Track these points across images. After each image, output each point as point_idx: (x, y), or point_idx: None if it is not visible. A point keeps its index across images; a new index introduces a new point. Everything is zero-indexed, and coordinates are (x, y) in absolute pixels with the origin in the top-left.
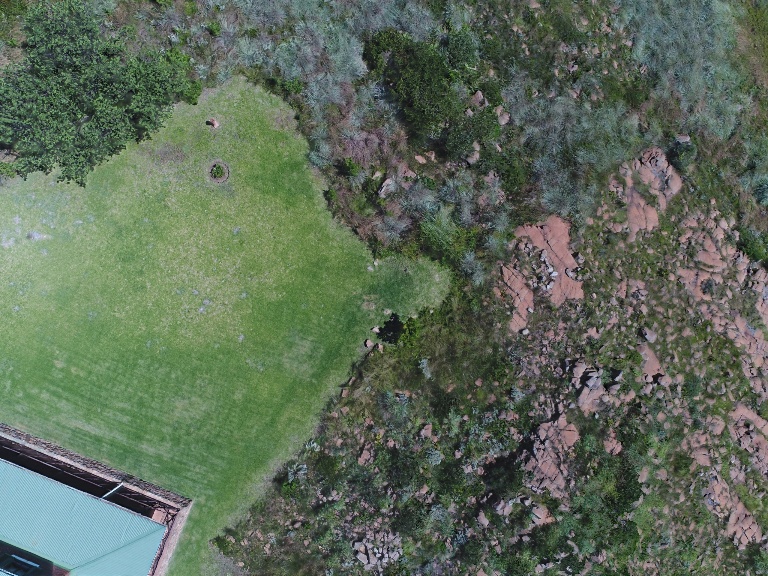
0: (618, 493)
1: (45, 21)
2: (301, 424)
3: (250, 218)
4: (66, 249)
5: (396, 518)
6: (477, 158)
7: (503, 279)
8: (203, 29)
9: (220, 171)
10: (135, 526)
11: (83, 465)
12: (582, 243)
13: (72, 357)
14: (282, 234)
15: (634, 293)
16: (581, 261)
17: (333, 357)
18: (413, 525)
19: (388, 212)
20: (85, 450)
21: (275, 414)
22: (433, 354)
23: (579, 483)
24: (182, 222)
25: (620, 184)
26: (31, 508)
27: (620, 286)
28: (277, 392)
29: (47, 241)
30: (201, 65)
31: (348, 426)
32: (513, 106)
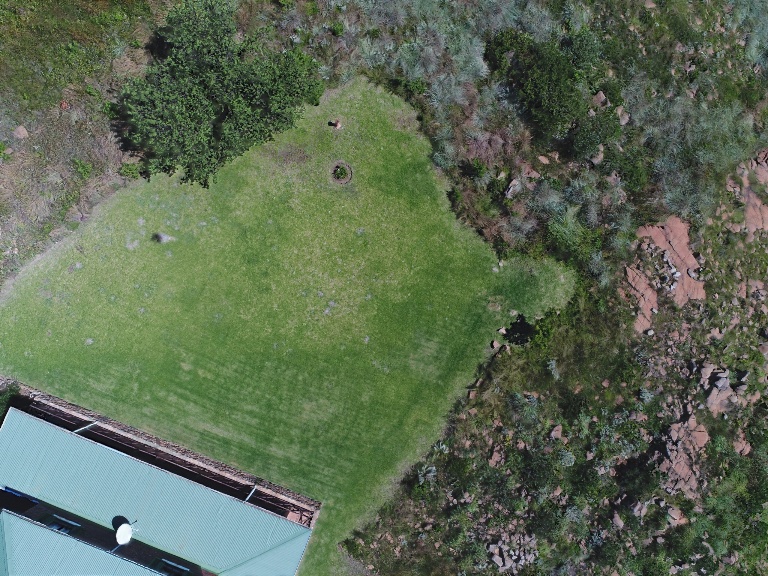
0: (749, 494)
1: (187, 22)
2: (428, 426)
3: (374, 219)
4: (191, 251)
5: (532, 520)
6: (601, 158)
7: (627, 280)
8: (326, 30)
9: (344, 172)
10: (281, 529)
11: (216, 468)
12: (702, 243)
13: (199, 359)
14: (406, 235)
15: (754, 293)
16: (702, 261)
17: (459, 358)
18: (552, 527)
19: (514, 213)
20: (213, 453)
21: (402, 416)
22: (561, 355)
23: (712, 484)
24: (306, 223)
25: (737, 184)
26: (176, 512)
27: (740, 286)
28: (404, 394)
29: (172, 243)
30: (323, 66)
31: (476, 428)
32: (633, 106)
